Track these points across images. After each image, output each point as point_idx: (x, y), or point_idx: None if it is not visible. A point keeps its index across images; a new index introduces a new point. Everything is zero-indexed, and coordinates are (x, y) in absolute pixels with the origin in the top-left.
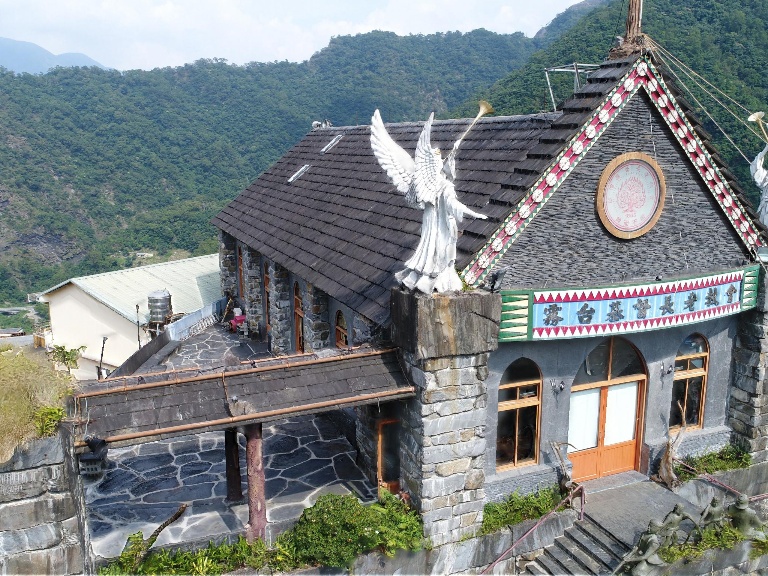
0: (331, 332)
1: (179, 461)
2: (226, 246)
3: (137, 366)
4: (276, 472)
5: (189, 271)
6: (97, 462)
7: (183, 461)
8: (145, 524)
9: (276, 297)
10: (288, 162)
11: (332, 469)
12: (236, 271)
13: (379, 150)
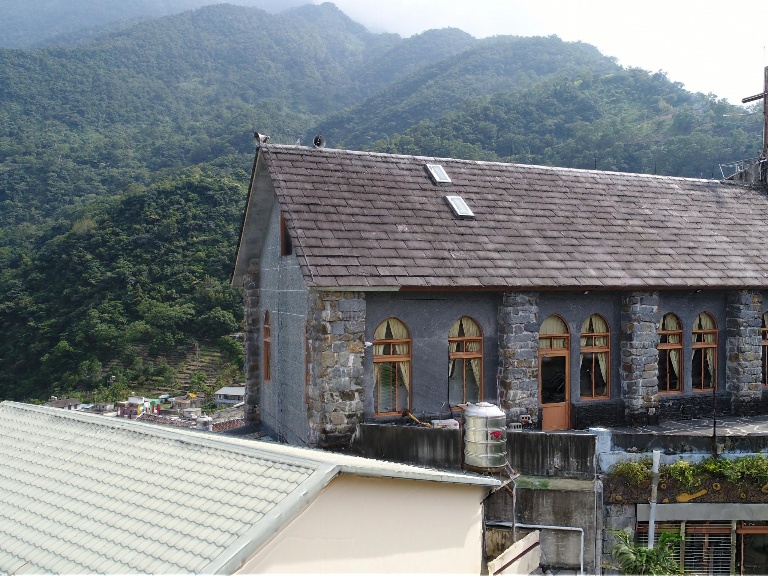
0: None
1: None
2: None
3: None
4: None
5: None
6: None
7: None
8: None
9: None
10: None
11: None
12: None
13: None
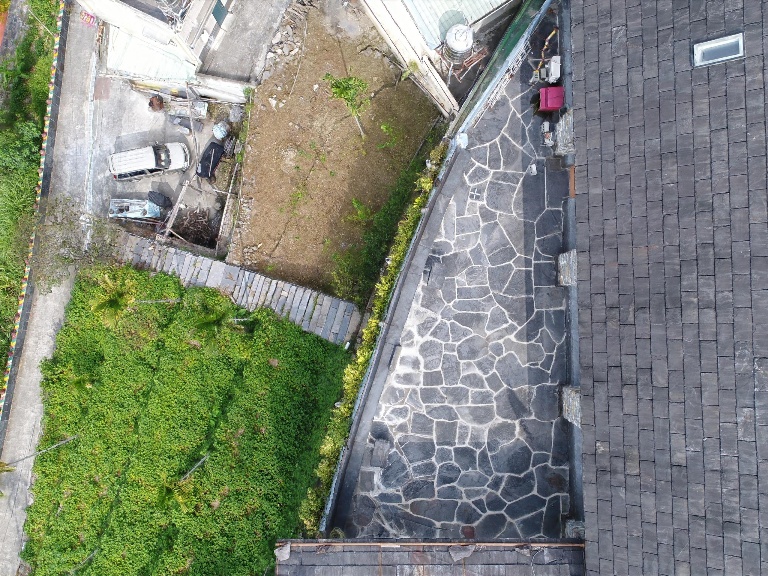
0: None
1: (439, 457)
2: None
3: (419, 239)
4: (503, 505)
5: None
6: None
7: (441, 458)
8: None
9: None
10: None
11: (542, 517)
12: None
13: None
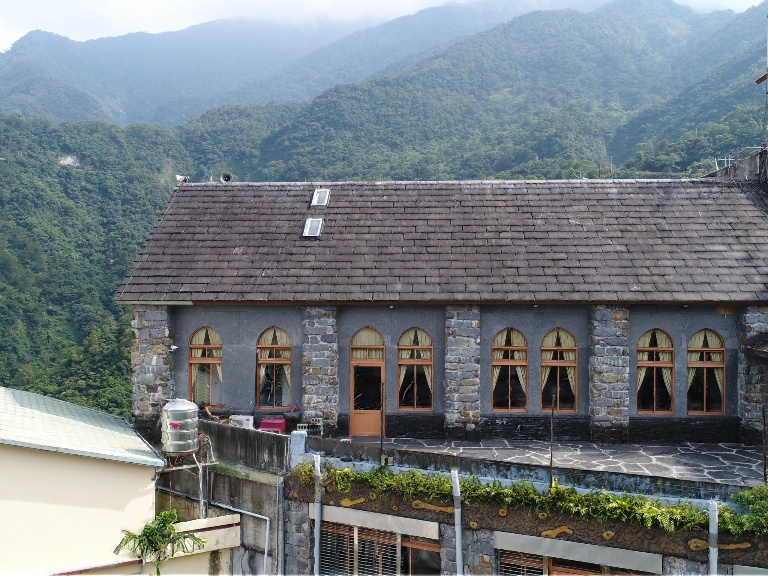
0: None
1: None
2: (169, 333)
3: None
4: (767, 463)
5: None
6: None
7: None
8: None
9: None
10: (219, 218)
11: (760, 451)
12: (175, 370)
13: None
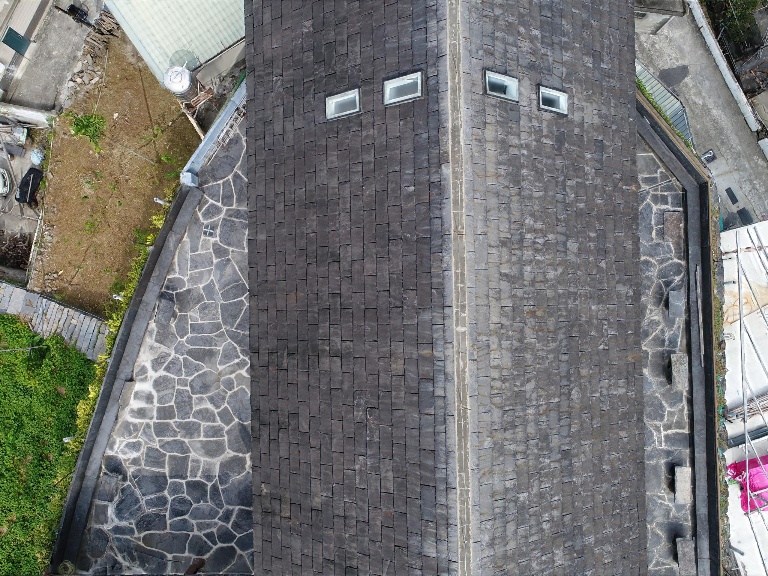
0: None
1: (171, 490)
2: None
3: (149, 276)
4: (233, 537)
5: None
6: None
7: (173, 491)
8: (142, 573)
9: None
10: None
11: None
12: None
13: None
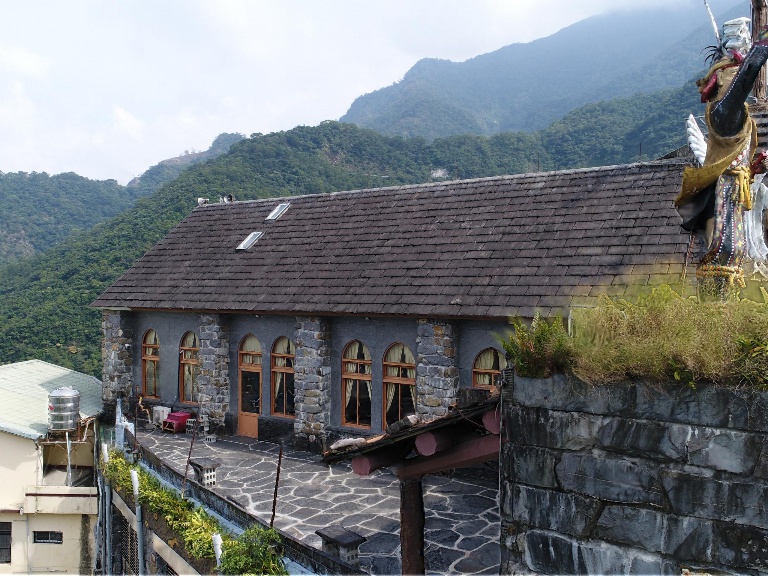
0: (462, 378)
1: None
2: (123, 333)
3: None
4: None
5: (22, 378)
6: (358, 545)
7: None
8: None
9: (320, 362)
10: (198, 235)
11: None
12: (133, 365)
13: (701, 149)
